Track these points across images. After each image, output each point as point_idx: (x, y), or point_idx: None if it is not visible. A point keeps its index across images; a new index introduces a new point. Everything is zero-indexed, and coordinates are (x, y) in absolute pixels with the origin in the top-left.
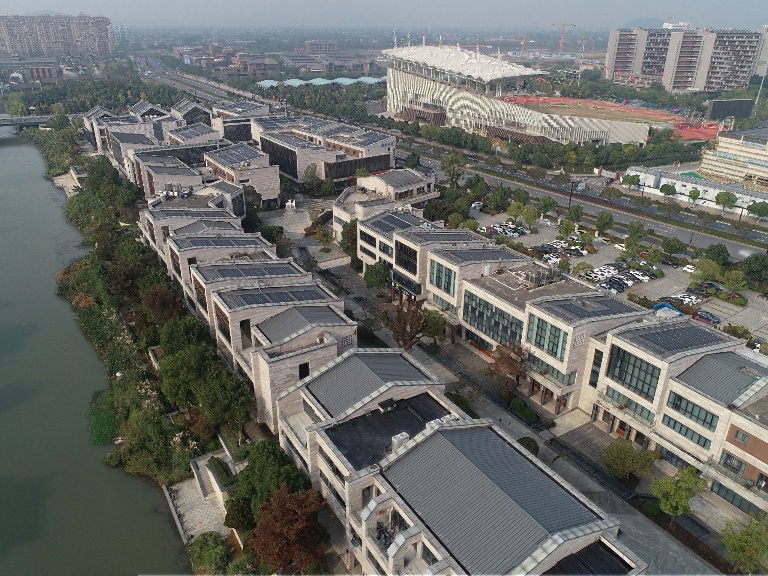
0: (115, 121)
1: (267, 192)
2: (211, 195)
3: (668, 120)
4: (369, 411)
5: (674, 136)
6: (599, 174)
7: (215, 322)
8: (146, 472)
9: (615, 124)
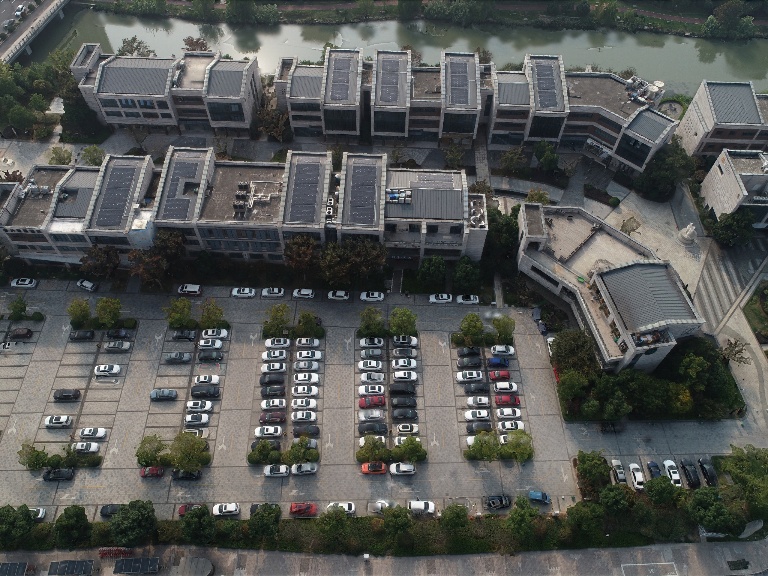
0: None
1: (720, 205)
2: None
3: None
4: None
5: None
6: None
7: None
8: None
9: None
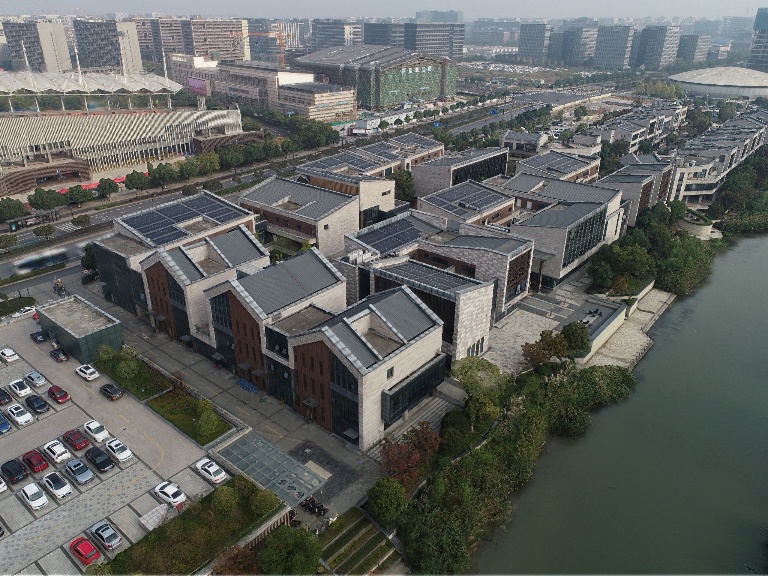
0: (488, 249)
1: None
2: None
3: None
4: None
5: None
6: None
7: None
8: None
9: None
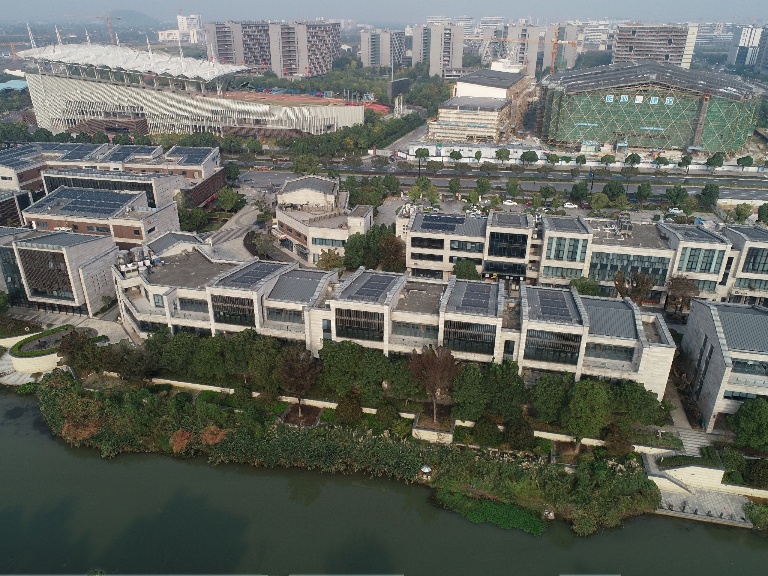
0: None
1: None
2: (186, 252)
3: (328, 103)
4: None
5: (375, 114)
6: (375, 154)
7: (523, 353)
8: (626, 514)
9: (340, 109)
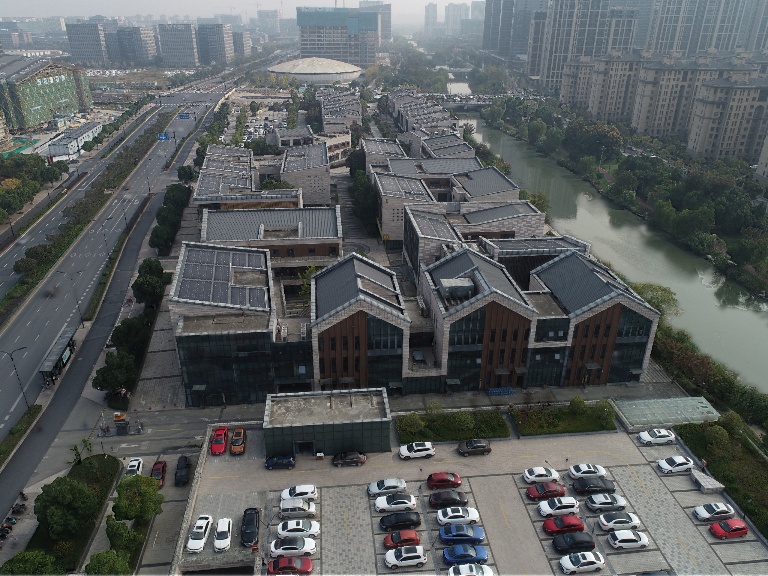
0: None
1: None
2: None
3: None
4: None
5: None
6: None
7: None
8: None
9: None
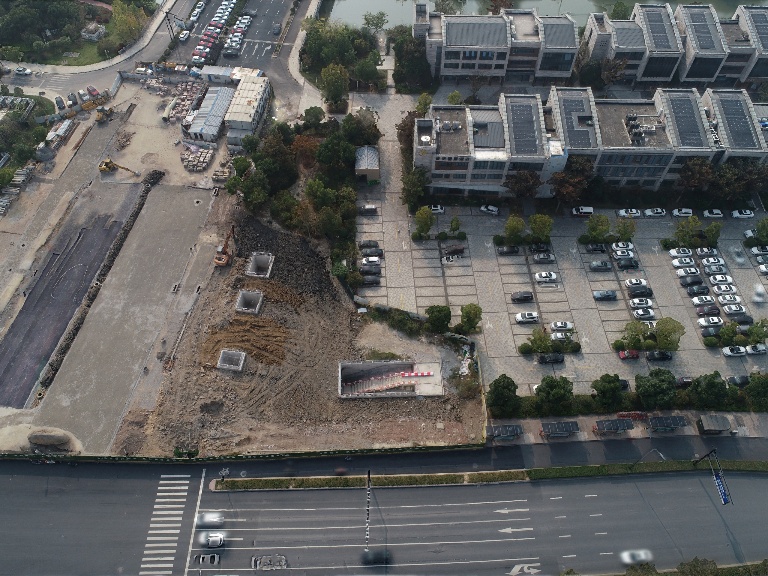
0: None
1: None
2: None
3: None
4: (536, 24)
5: None
6: None
7: None
8: None
9: None
